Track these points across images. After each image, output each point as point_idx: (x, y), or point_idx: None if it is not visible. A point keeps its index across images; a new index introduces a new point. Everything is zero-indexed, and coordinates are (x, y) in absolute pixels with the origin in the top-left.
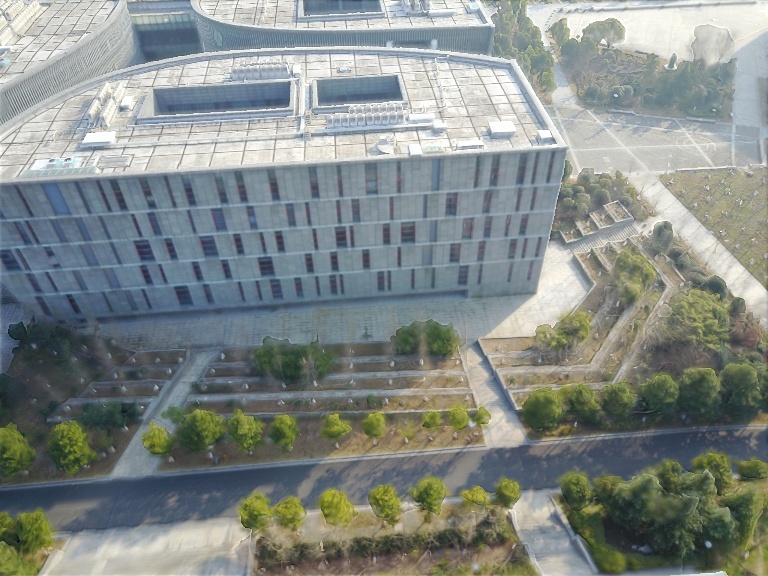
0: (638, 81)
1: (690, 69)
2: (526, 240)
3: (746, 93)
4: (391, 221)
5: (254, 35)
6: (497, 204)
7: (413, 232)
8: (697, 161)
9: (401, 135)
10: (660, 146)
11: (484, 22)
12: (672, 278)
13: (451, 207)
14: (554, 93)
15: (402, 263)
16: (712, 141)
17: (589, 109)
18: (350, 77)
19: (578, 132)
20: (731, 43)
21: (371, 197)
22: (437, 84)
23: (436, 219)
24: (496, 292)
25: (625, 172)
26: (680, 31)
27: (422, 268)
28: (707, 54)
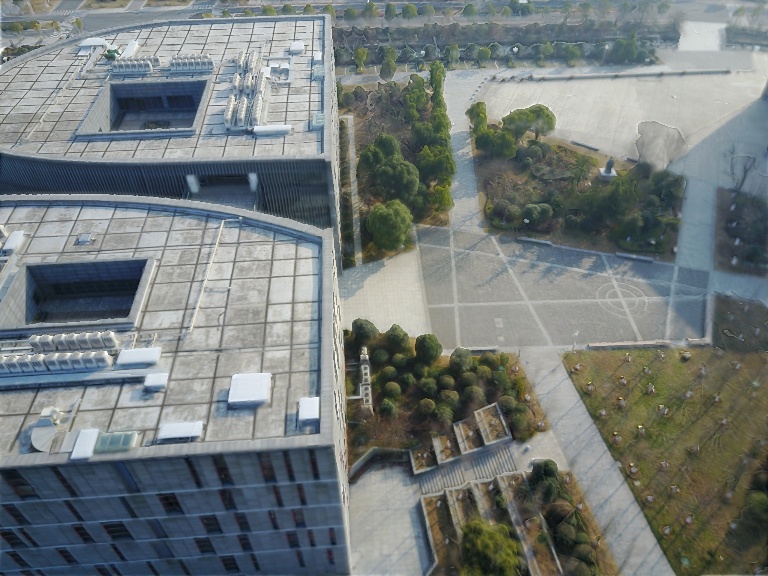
0: (557, 200)
1: (622, 190)
2: (310, 531)
3: (699, 213)
4: (82, 522)
5: (8, 162)
6: (246, 501)
7: (126, 530)
8: (619, 328)
9: (93, 394)
10: (574, 301)
11: (322, 149)
12: (544, 565)
13: (173, 505)
14: (455, 207)
15: (127, 557)
16: (644, 294)
17: (494, 234)
18: (77, 261)
19: (471, 273)
20: (682, 147)
21: (33, 501)
22: (203, 275)
23: (155, 518)
24: (289, 575)
25: (519, 347)
26: (632, 112)
27: (162, 560)
28: (651, 160)
